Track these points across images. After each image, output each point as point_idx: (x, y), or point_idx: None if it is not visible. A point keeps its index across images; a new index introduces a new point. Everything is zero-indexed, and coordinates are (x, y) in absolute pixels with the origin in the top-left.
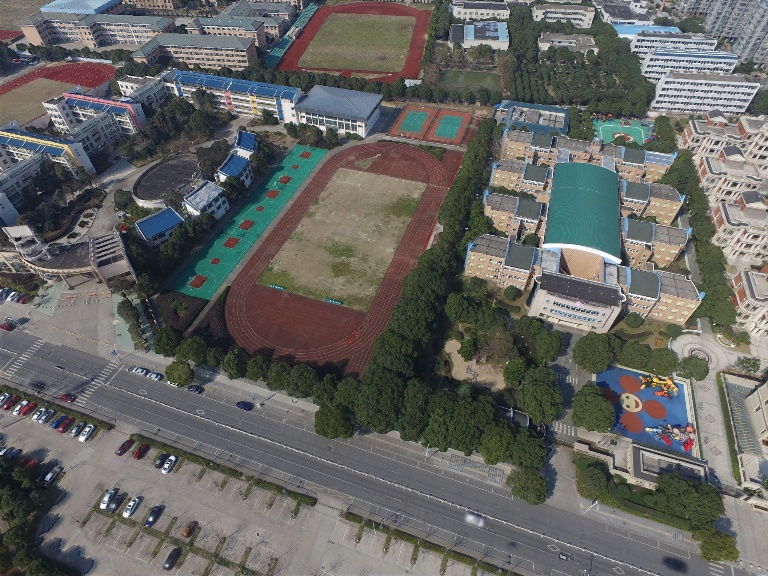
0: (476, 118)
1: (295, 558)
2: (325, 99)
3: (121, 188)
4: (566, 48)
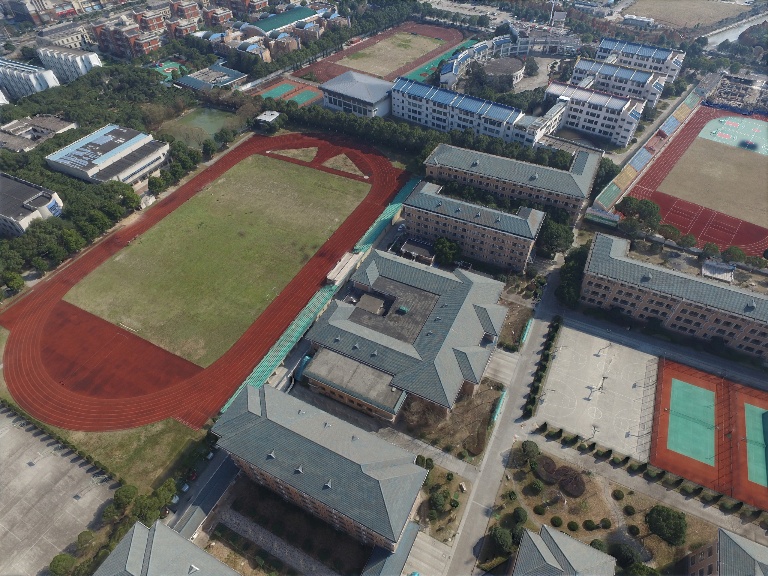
0: (248, 94)
1: (443, 6)
2: (374, 83)
3: (541, 83)
4: (74, 107)
